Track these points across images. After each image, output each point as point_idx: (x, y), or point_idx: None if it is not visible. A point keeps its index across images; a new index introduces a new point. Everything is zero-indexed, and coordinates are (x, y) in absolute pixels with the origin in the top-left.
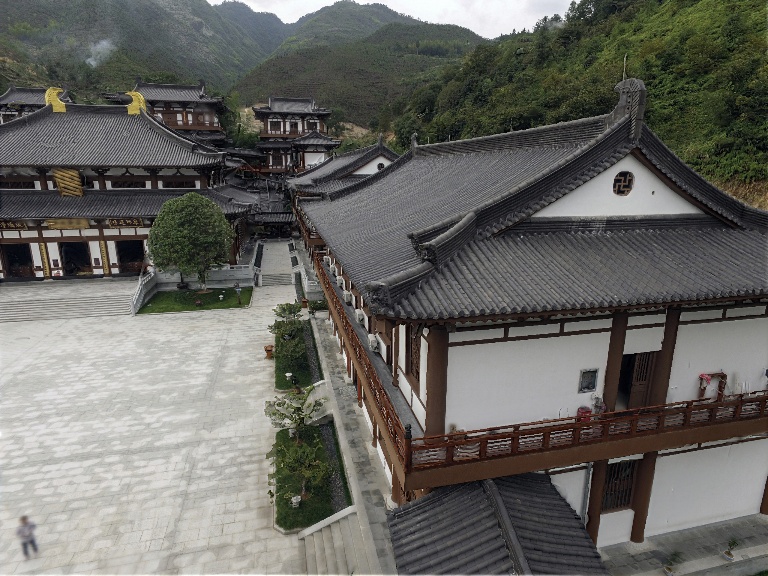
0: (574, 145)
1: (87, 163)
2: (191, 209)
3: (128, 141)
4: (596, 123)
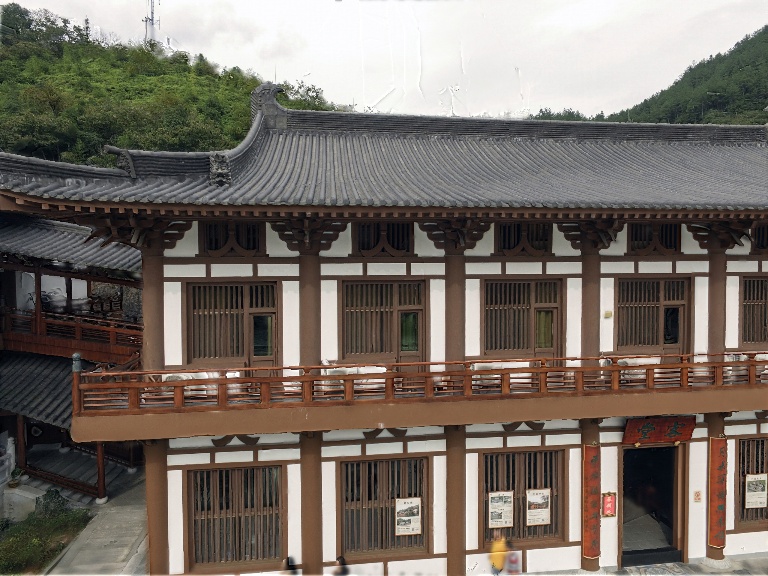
0: (737, 144)
1: None
2: None
3: None
4: (758, 130)
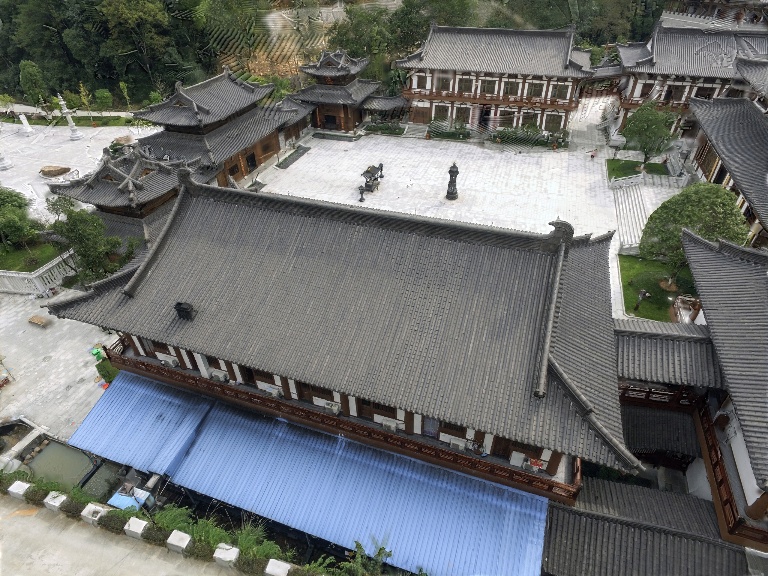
0: None
1: None
2: (682, 199)
3: None
4: None
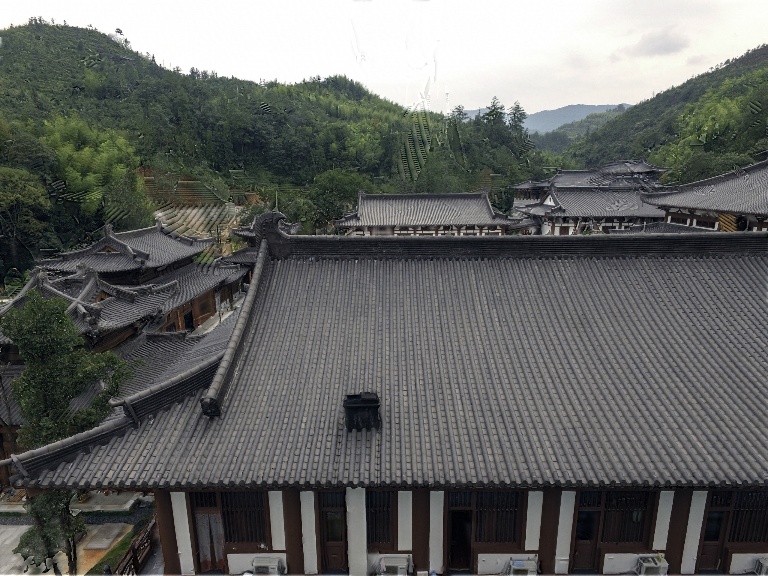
0: None
1: (741, 209)
2: None
3: None
4: None
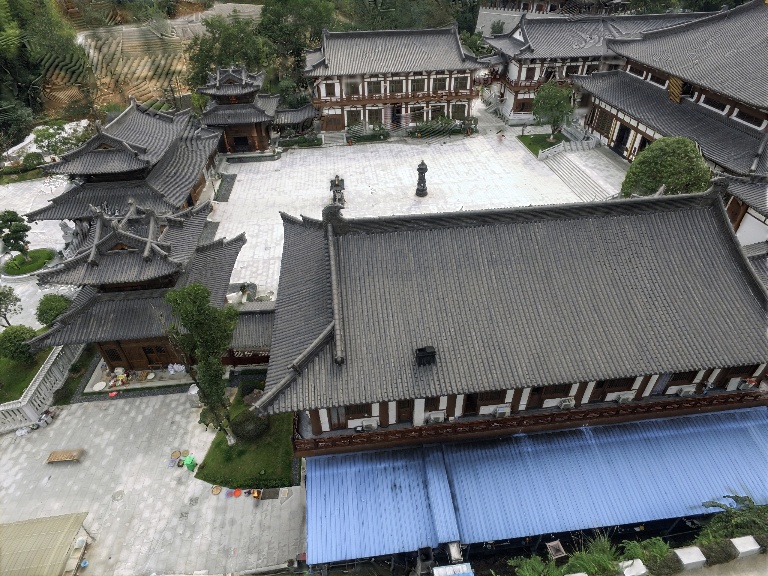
0: None
1: (688, 76)
2: (659, 153)
3: (766, 54)
4: None
